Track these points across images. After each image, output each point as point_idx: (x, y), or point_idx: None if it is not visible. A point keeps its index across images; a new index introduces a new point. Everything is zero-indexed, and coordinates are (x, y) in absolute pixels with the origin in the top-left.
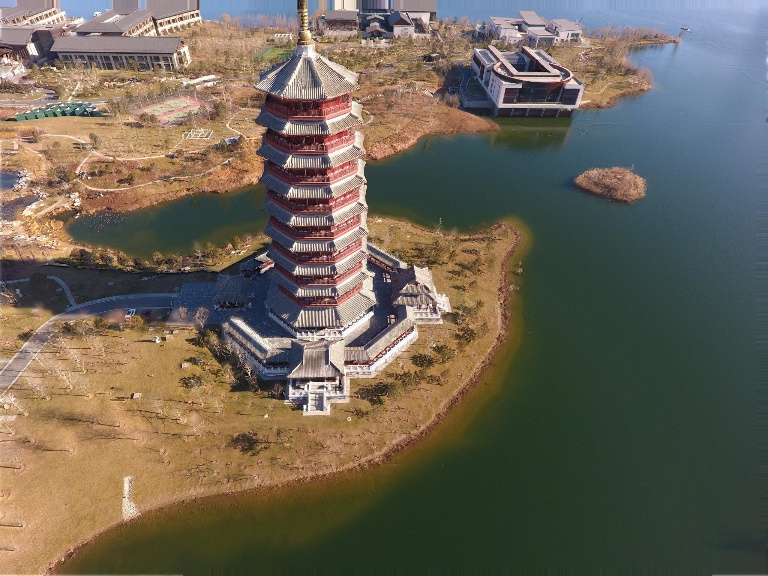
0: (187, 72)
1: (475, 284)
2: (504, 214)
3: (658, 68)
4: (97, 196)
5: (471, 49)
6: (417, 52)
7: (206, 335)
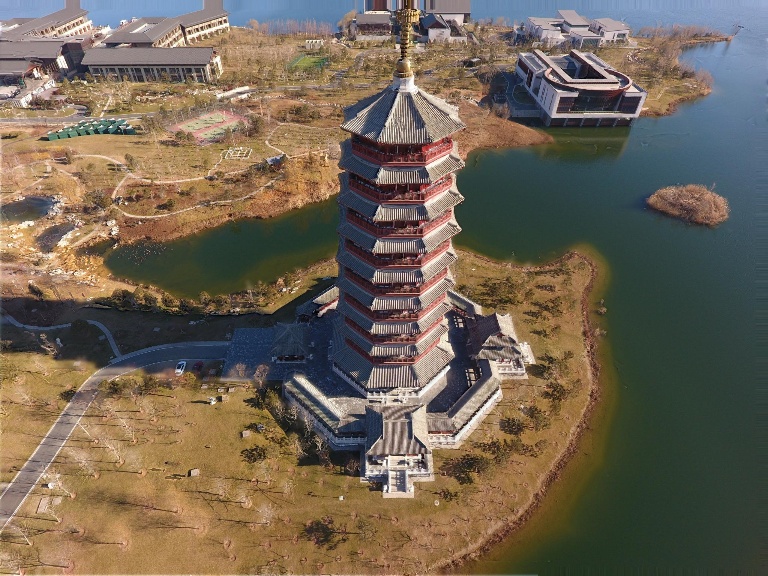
0: (220, 84)
1: (559, 329)
2: (574, 241)
3: (716, 70)
4: (135, 224)
5: (513, 53)
6: (455, 57)
7: (267, 396)
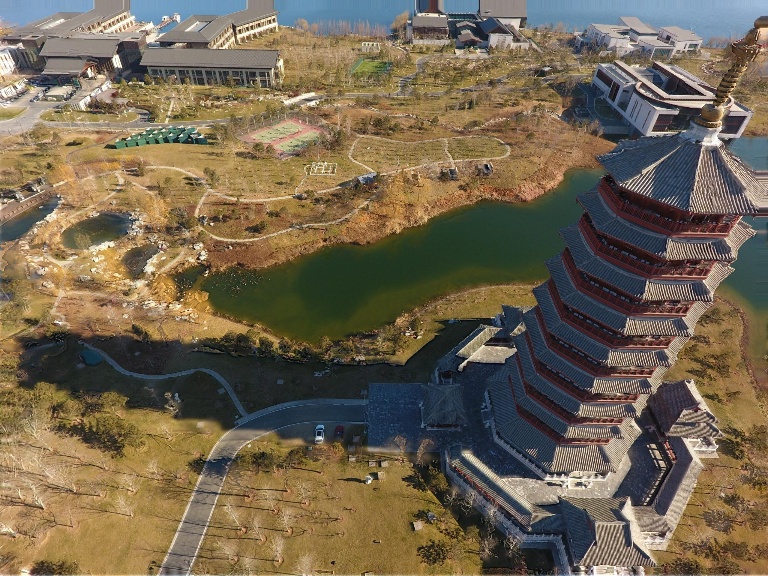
0: (285, 89)
1: (737, 395)
2: None
3: None
4: (225, 248)
5: (586, 63)
6: (520, 64)
7: (433, 477)
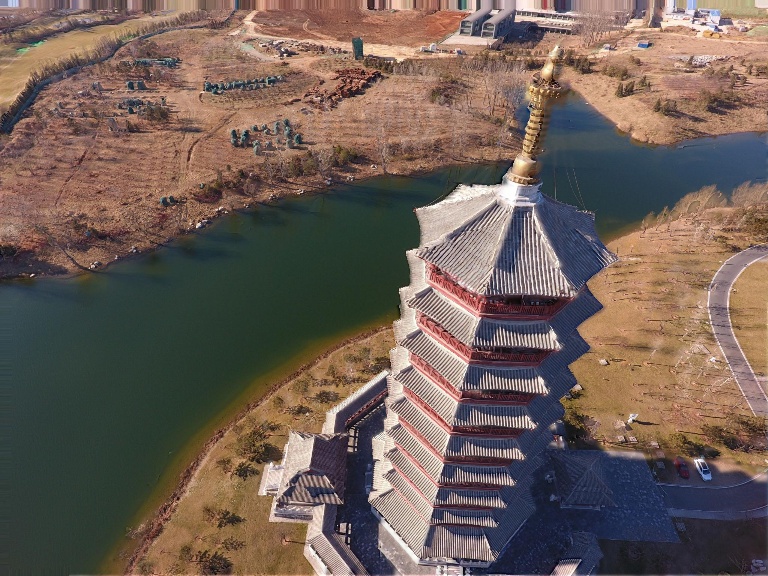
0: None
1: None
2: None
3: None
4: None
5: None
6: None
7: None
